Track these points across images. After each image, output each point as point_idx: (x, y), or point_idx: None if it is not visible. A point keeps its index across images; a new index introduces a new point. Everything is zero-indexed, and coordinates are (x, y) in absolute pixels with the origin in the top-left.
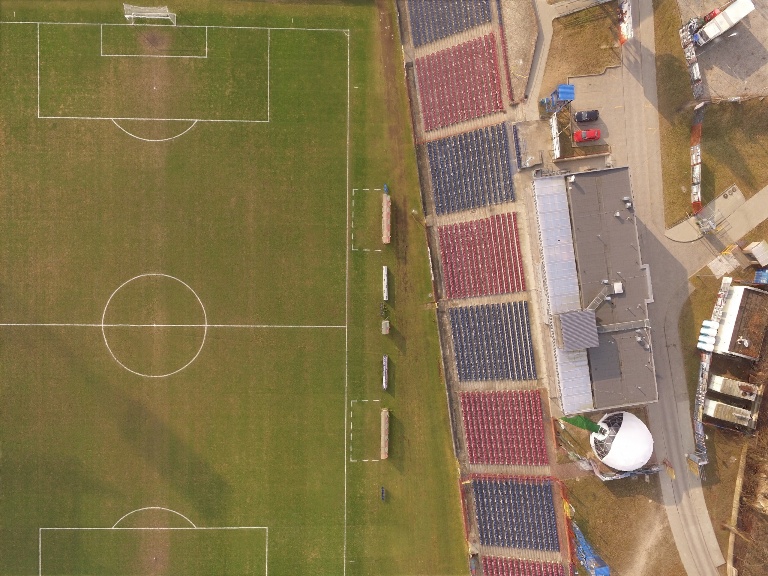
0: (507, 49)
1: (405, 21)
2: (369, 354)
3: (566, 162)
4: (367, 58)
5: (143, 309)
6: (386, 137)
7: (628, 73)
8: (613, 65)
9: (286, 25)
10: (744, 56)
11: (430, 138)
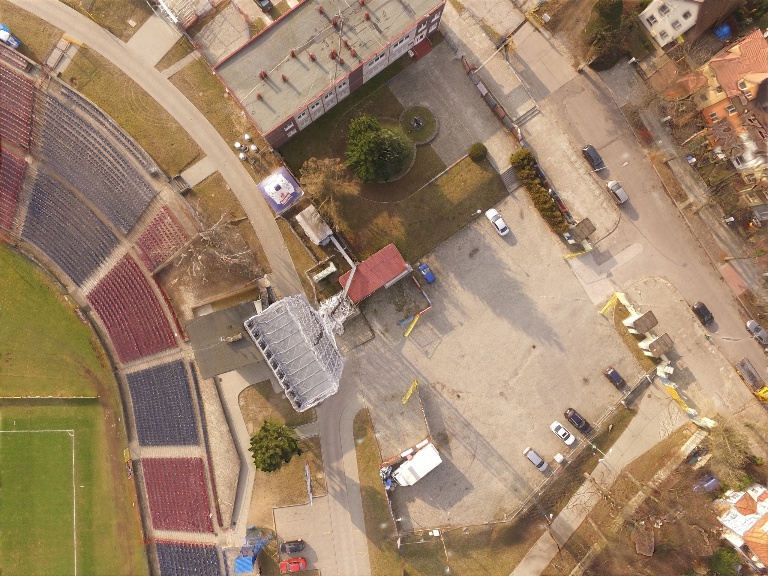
0: (215, 475)
1: (132, 417)
2: None
3: None
4: (93, 457)
5: None
6: (115, 534)
7: (334, 501)
8: (318, 495)
9: (8, 428)
10: (446, 487)
11: (158, 536)
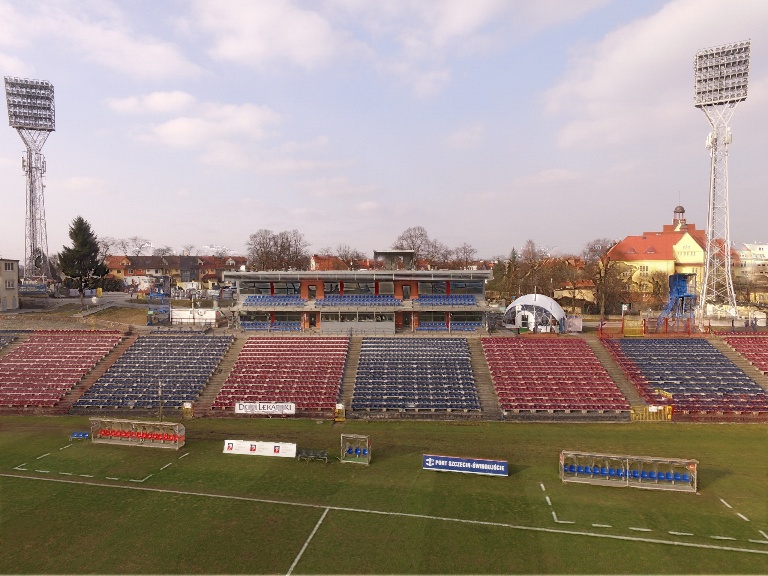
0: None
1: None
2: (416, 484)
3: (225, 325)
4: None
5: None
6: None
7: None
8: None
9: None
10: None
11: (70, 402)
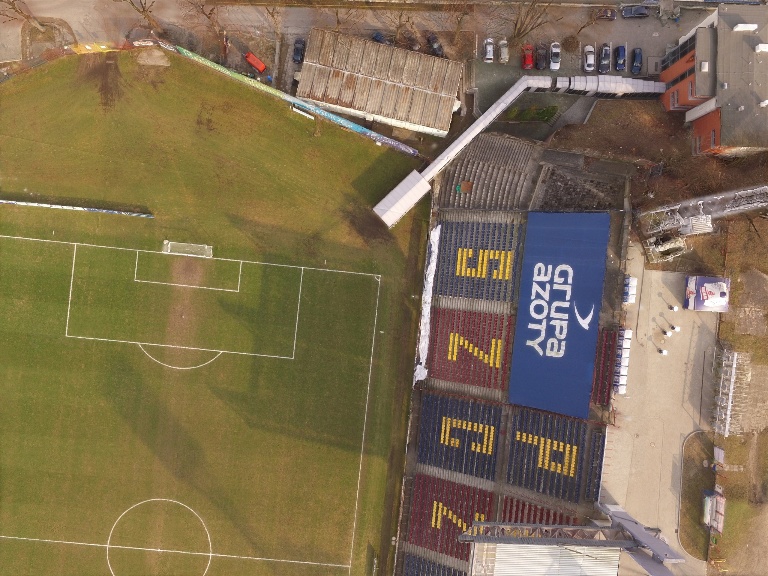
0: None
1: None
2: None
3: None
4: None
5: (169, 568)
6: None
7: None
8: None
9: None
10: None
11: None
